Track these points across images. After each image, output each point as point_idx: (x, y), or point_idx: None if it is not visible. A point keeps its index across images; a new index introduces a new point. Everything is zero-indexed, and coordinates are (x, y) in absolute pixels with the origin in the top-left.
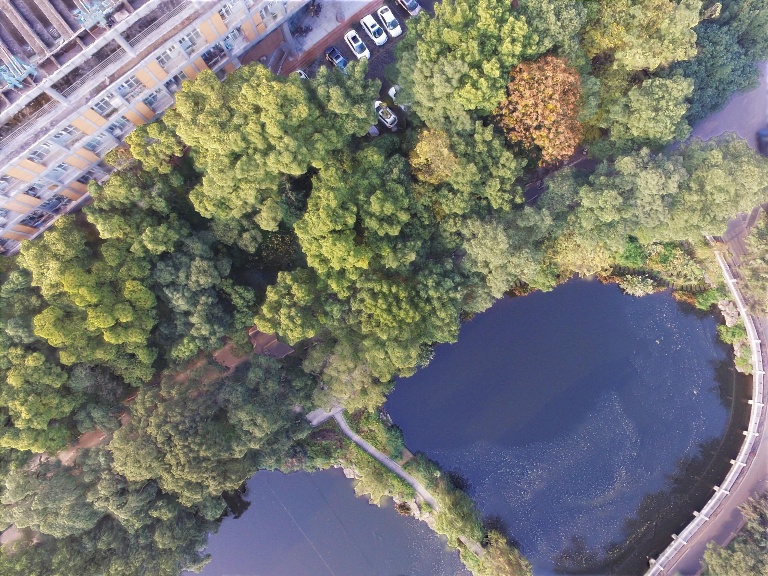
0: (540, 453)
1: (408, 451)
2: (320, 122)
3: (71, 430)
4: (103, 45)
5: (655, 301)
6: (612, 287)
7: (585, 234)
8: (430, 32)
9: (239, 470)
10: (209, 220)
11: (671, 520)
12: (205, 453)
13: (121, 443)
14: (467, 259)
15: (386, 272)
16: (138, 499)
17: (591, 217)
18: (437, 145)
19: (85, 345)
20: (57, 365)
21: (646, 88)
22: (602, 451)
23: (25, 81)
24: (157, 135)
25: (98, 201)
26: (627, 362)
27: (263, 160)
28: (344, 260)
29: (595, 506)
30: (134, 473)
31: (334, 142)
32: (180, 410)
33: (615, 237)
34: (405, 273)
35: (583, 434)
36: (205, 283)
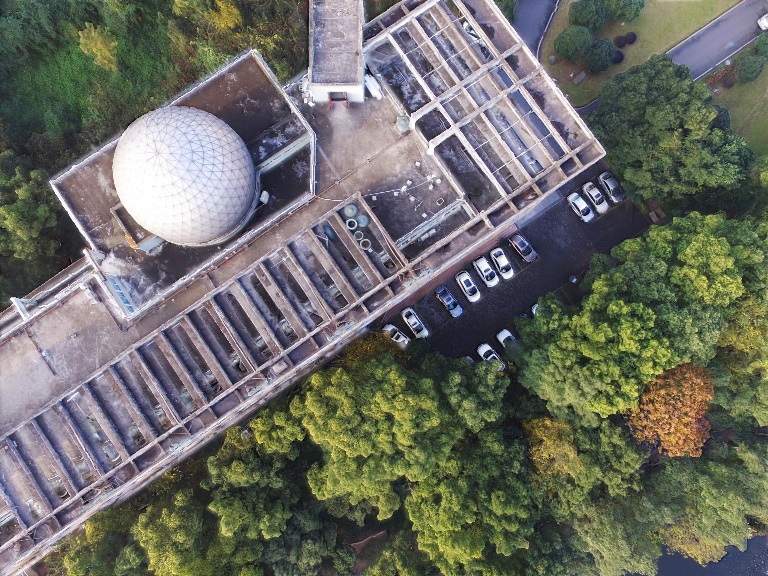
0: None
1: None
2: (447, 420)
3: None
4: None
5: (753, 546)
6: None
7: (705, 530)
8: (566, 340)
9: None
10: None
11: None
12: None
13: None
14: (577, 539)
15: (492, 546)
16: None
17: (714, 518)
18: (563, 448)
19: None
20: None
21: None
22: None
23: (181, 431)
24: (283, 424)
25: (217, 478)
26: None
27: (391, 468)
28: None
29: None
30: None
31: (458, 437)
32: None
33: (736, 535)
34: (513, 552)
35: None
36: None
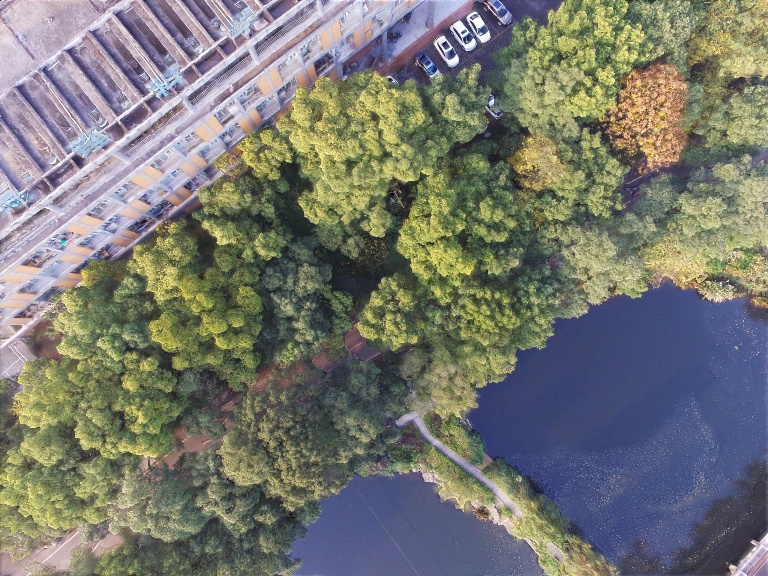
0: (619, 458)
1: (488, 456)
2: (431, 129)
3: (176, 434)
4: (242, 54)
5: (734, 307)
6: (690, 293)
7: (686, 241)
8: (543, 40)
9: (341, 475)
10: (313, 226)
11: (750, 526)
12: (316, 458)
13: (233, 448)
14: (565, 265)
15: (484, 278)
16: (246, 504)
17: (693, 224)
18: (546, 152)
19: (197, 350)
20: (168, 370)
21: (747, 95)
22: (681, 457)
23: None
24: (270, 142)
25: (209, 207)
26: (706, 368)
27: (380, 167)
28: (451, 266)
29: (674, 512)
30: (245, 478)
31: (444, 149)
32: (292, 415)
33: (715, 244)
34: (504, 279)
35: (662, 440)
36: (311, 289)
